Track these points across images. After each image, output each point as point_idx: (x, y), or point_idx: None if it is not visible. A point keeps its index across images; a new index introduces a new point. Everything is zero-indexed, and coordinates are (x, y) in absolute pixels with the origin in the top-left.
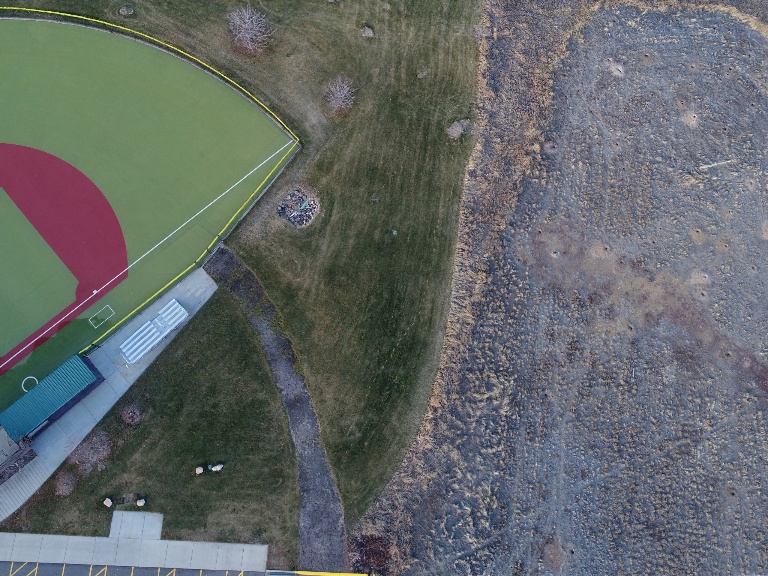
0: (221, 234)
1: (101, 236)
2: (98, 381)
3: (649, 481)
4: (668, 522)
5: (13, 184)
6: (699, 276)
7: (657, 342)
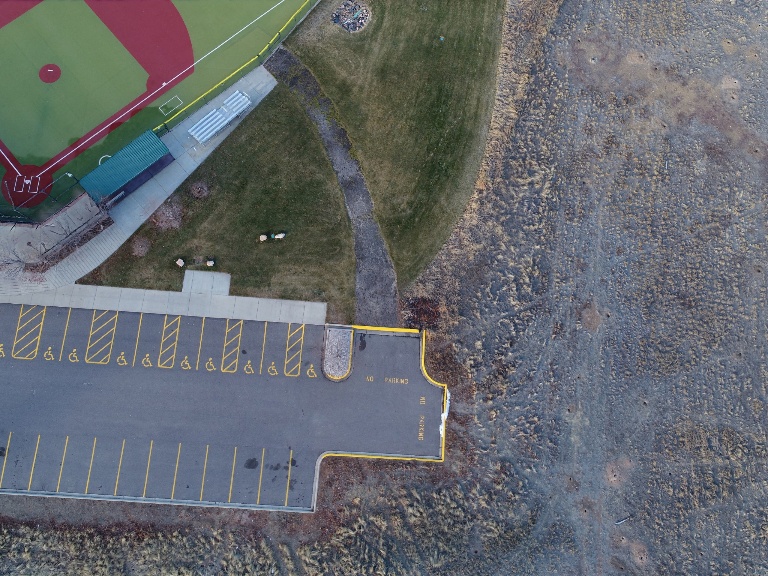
0: (280, 36)
1: (169, 36)
2: (169, 160)
3: (680, 258)
4: (698, 293)
5: None
6: (730, 81)
7: (689, 139)
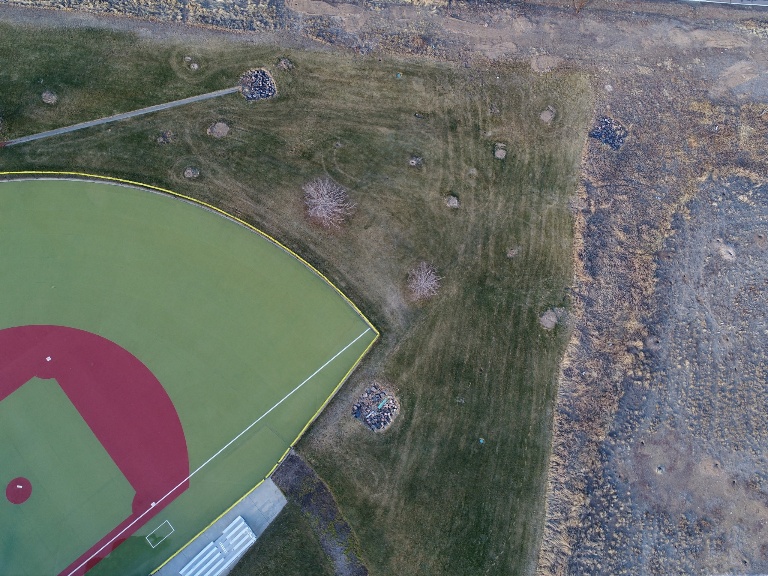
0: (292, 439)
1: (161, 438)
2: None
3: None
4: None
5: (67, 374)
6: None
7: None
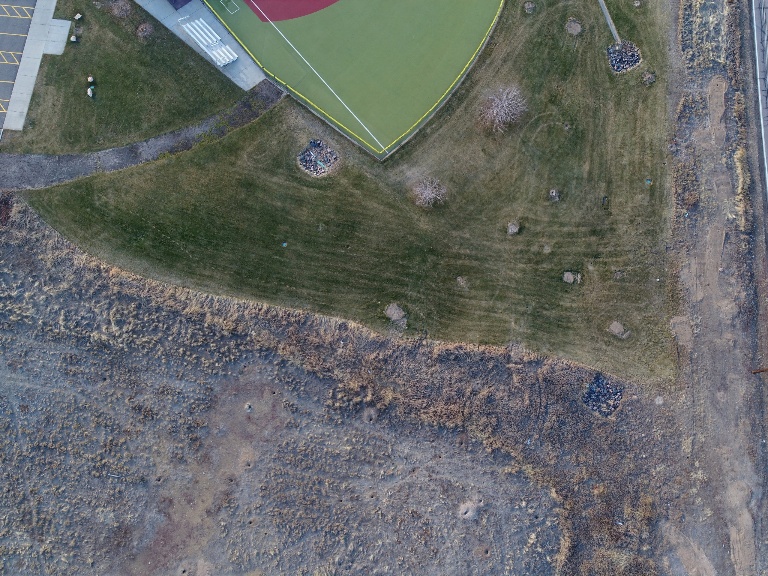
0: None
1: (301, 0)
2: (176, 5)
3: (5, 474)
4: None
5: None
6: (205, 571)
7: (140, 508)
